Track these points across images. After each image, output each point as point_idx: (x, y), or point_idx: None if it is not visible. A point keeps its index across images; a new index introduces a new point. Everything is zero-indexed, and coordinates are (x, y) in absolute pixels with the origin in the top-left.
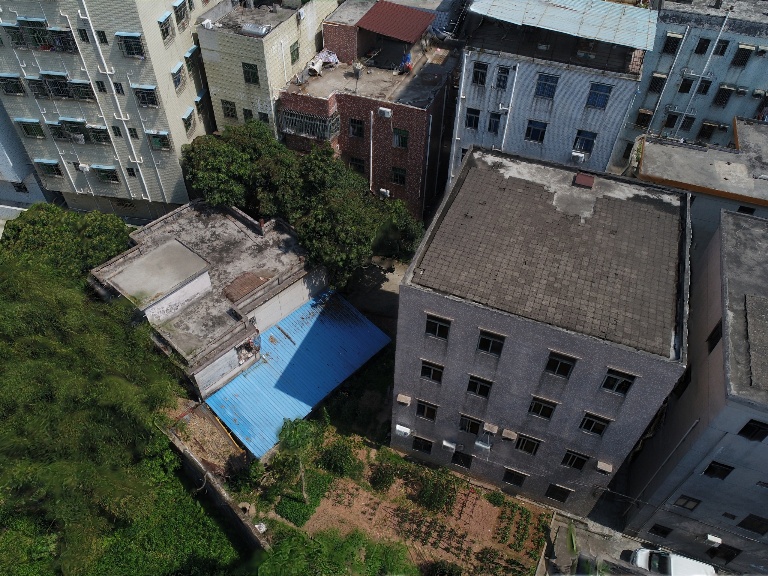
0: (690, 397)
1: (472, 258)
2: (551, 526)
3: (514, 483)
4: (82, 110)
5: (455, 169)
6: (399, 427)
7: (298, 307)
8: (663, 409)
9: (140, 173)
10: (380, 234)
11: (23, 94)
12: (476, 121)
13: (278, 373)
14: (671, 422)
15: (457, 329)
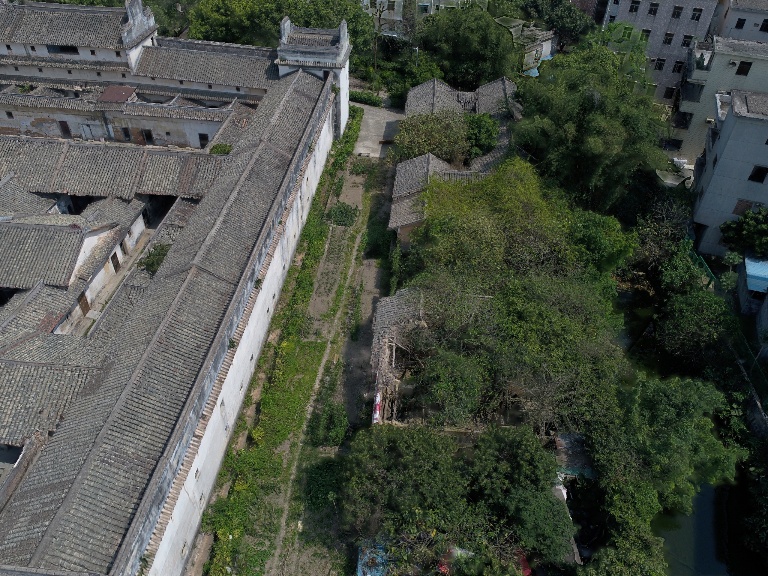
0: None
1: None
2: None
3: (651, 95)
4: None
5: (610, 6)
6: None
7: (546, 56)
8: None
9: None
10: (584, 22)
11: None
12: None
13: None
14: None
15: (642, 5)
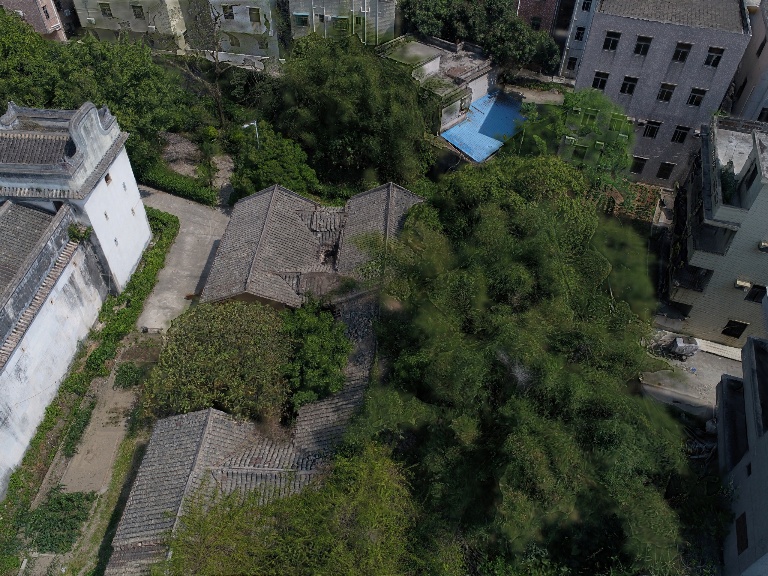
0: (747, 87)
1: (628, 7)
2: (661, 193)
3: (637, 172)
4: None
5: (577, 13)
6: (568, 137)
7: (481, 97)
8: (731, 102)
9: (365, 21)
10: (537, 45)
11: None
12: None
13: (479, 126)
14: (735, 111)
15: (624, 40)
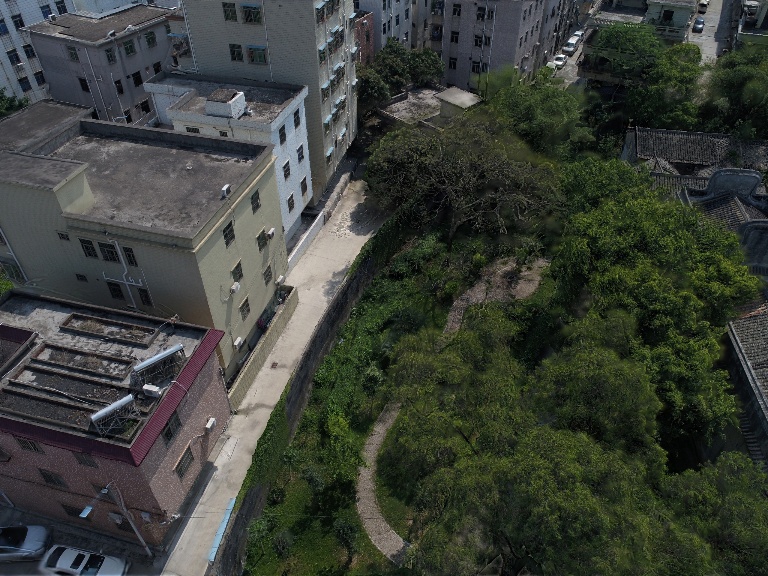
0: None
1: None
2: None
3: None
4: (339, 90)
5: (382, 38)
6: None
7: None
8: None
9: None
10: None
11: (326, 98)
12: (385, 5)
13: None
14: None
15: None
